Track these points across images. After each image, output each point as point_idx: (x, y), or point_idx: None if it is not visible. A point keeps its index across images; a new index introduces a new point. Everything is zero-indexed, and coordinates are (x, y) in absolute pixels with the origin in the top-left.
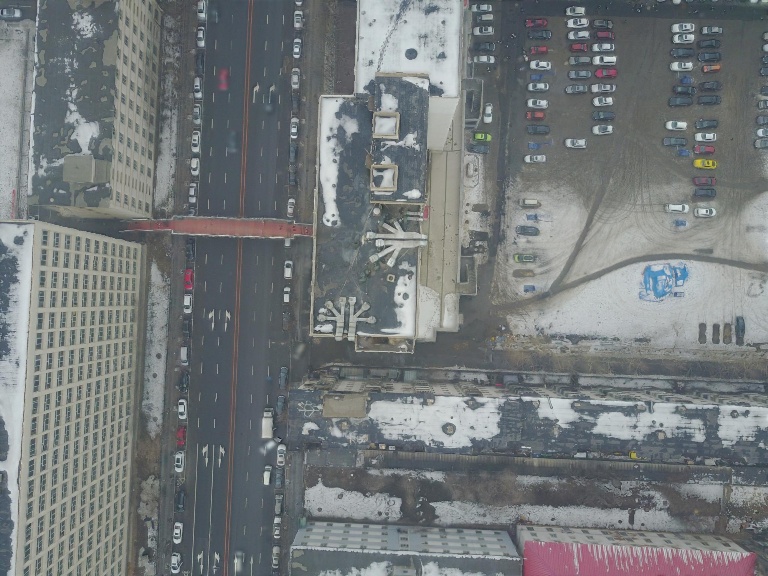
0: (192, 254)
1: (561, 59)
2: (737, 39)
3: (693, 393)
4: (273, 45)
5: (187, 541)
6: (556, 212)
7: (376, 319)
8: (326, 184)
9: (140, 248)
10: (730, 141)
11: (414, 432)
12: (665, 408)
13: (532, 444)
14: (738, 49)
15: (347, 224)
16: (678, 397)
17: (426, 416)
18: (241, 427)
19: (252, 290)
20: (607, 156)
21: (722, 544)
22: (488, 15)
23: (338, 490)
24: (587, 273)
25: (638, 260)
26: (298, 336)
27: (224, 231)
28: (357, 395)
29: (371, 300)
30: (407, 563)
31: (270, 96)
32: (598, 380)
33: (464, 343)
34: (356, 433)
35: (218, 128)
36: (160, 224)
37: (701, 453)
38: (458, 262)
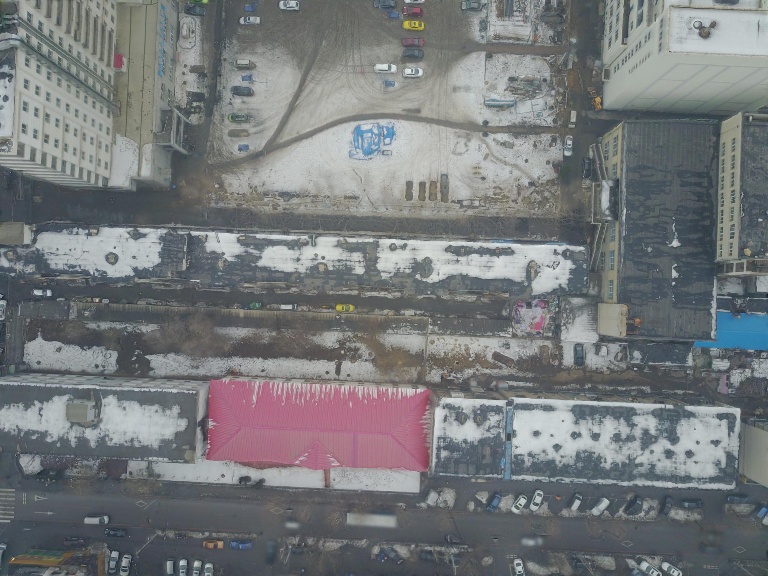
0: None
1: None
2: None
3: None
4: None
5: None
6: (270, 73)
7: None
8: None
9: None
10: (439, 3)
11: (79, 262)
12: (327, 241)
13: (200, 277)
14: None
15: None
16: None
17: (90, 246)
18: None
19: None
20: (320, 18)
21: (411, 387)
22: None
23: (56, 344)
24: (299, 132)
25: (348, 120)
26: (20, 195)
27: None
28: None
29: None
30: (87, 396)
31: None
32: None
33: (180, 201)
34: (23, 263)
35: None
36: None
37: (406, 306)
38: (153, 112)
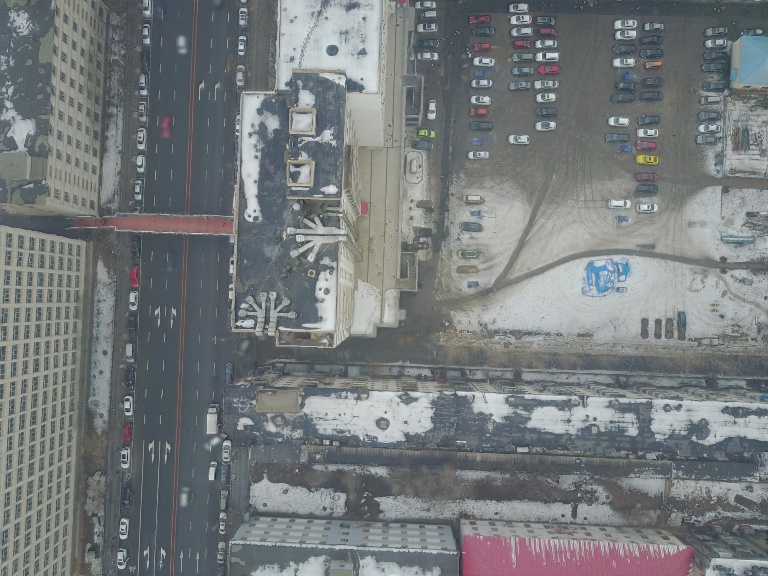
0: (138, 251)
1: (504, 56)
2: (679, 35)
3: (634, 388)
4: (218, 42)
5: (133, 537)
6: (500, 208)
7: (297, 314)
8: (248, 180)
9: (84, 245)
10: (672, 137)
11: (348, 427)
12: (599, 402)
13: (467, 438)
14: (680, 45)
15: (268, 220)
16: (614, 391)
17: (360, 411)
18: (187, 423)
19: (198, 287)
20: (550, 152)
21: (661, 537)
22: (431, 12)
23: (283, 485)
24: (530, 269)
25: (581, 256)
26: None
27: (167, 228)
28: (290, 390)
29: (292, 295)
30: (345, 557)
31: (215, 93)
32: (541, 375)
33: (408, 339)
34: (291, 428)
35: (164, 125)
36: (104, 221)
37: None
38: (398, 258)
